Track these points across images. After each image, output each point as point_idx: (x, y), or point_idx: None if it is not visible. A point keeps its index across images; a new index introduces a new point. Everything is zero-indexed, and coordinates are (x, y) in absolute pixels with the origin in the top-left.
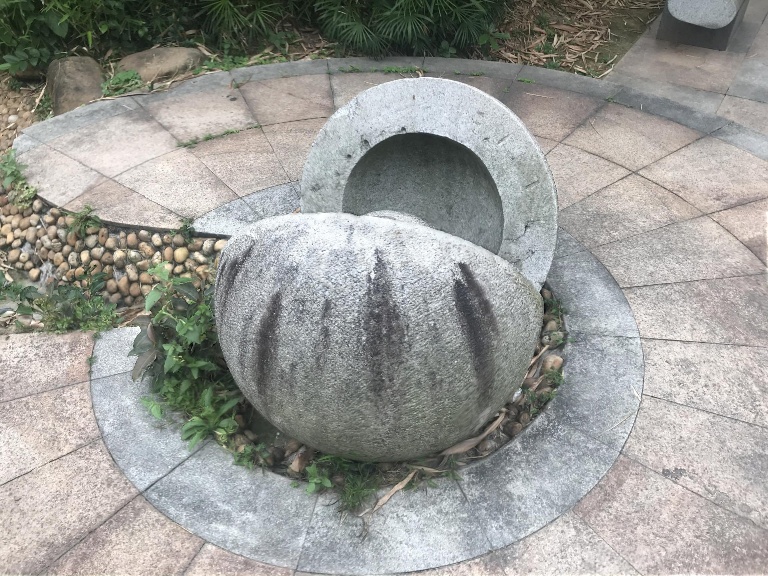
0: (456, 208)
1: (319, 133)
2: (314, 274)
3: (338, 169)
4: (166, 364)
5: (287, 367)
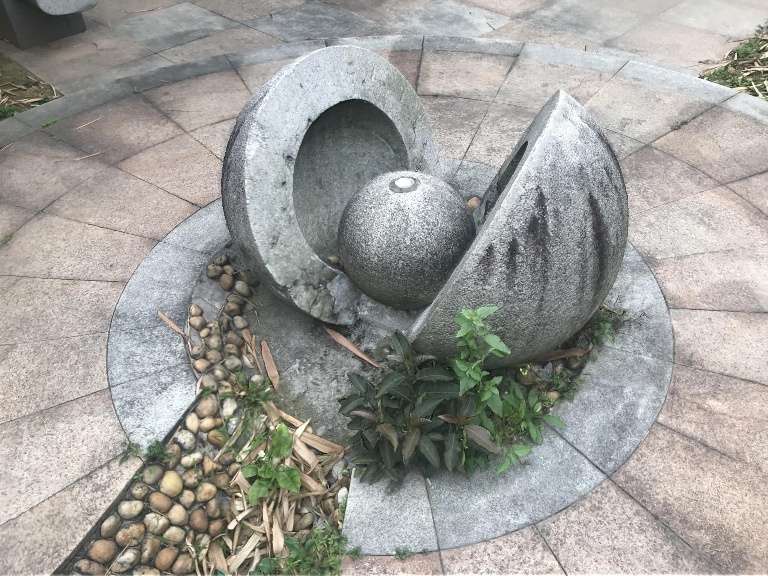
0: (325, 178)
1: (247, 185)
2: (590, 160)
3: (282, 205)
4: (495, 410)
5: (615, 240)
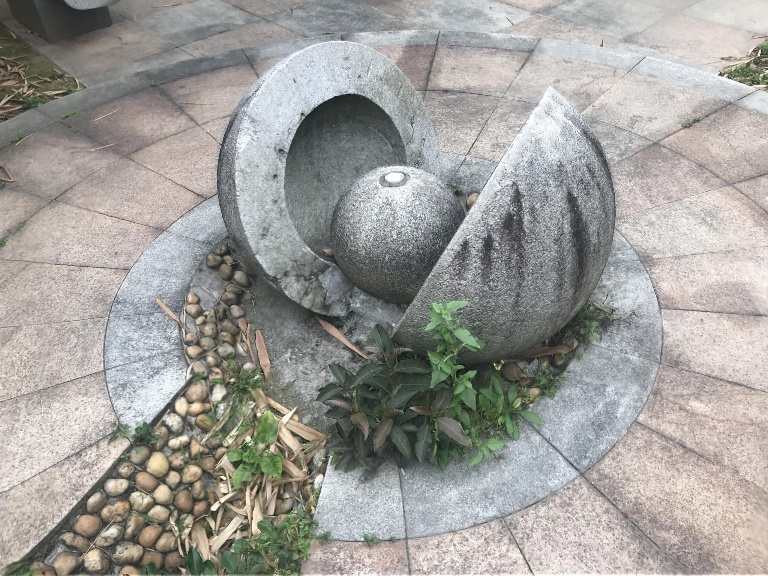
0: (323, 172)
1: (237, 178)
2: (570, 157)
3: (273, 197)
4: (468, 404)
5: (596, 238)
